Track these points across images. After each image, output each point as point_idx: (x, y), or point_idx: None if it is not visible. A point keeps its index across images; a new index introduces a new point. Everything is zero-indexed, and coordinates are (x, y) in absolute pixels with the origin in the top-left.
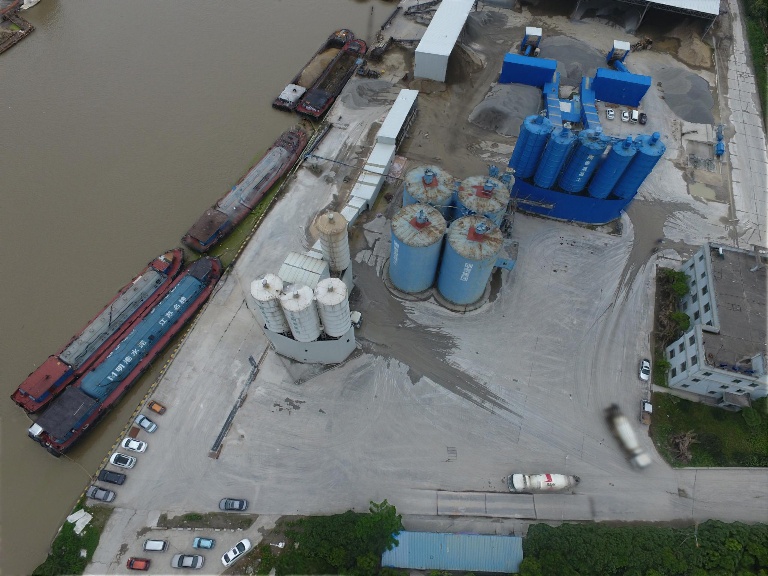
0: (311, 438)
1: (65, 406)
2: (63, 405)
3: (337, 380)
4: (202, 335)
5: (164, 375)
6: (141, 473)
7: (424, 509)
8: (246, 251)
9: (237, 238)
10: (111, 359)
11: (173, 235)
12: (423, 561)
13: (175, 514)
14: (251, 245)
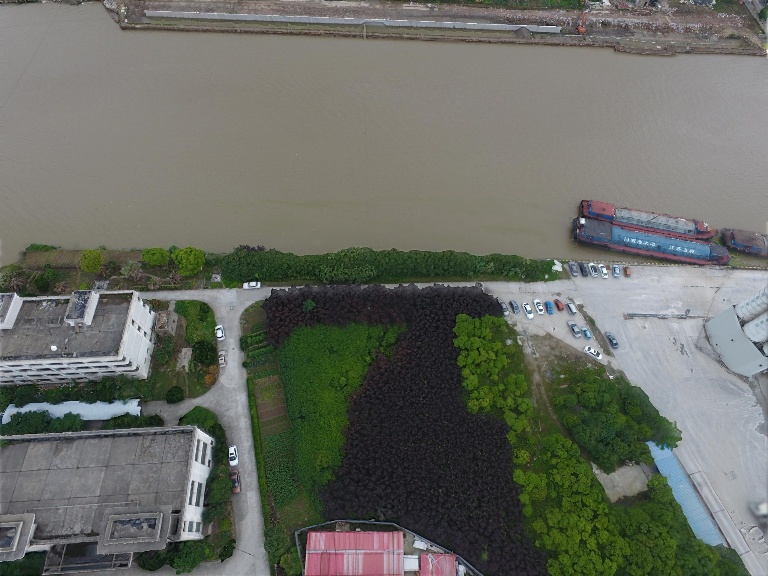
0: (673, 370)
1: (600, 226)
2: (600, 225)
3: (717, 372)
4: (679, 274)
5: (644, 266)
6: (593, 283)
7: (686, 464)
8: (750, 271)
9: (751, 261)
10: (635, 233)
11: (720, 222)
12: (664, 470)
13: (587, 311)
14: (756, 272)
